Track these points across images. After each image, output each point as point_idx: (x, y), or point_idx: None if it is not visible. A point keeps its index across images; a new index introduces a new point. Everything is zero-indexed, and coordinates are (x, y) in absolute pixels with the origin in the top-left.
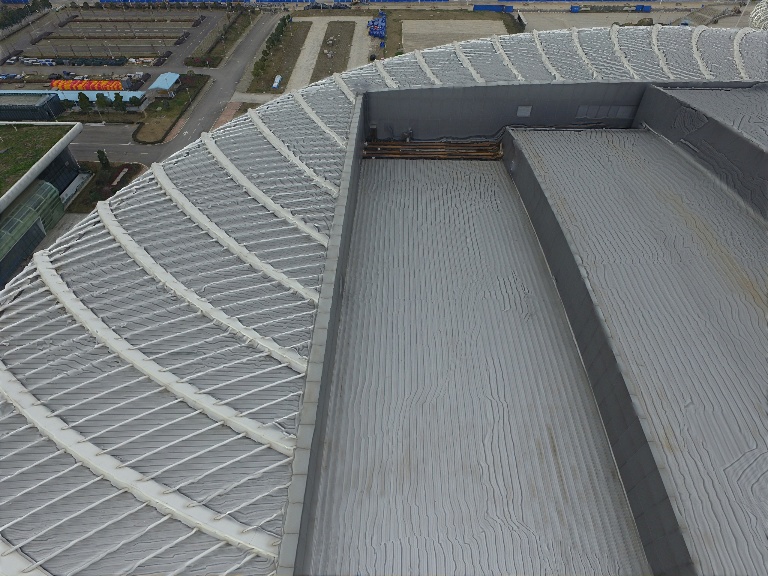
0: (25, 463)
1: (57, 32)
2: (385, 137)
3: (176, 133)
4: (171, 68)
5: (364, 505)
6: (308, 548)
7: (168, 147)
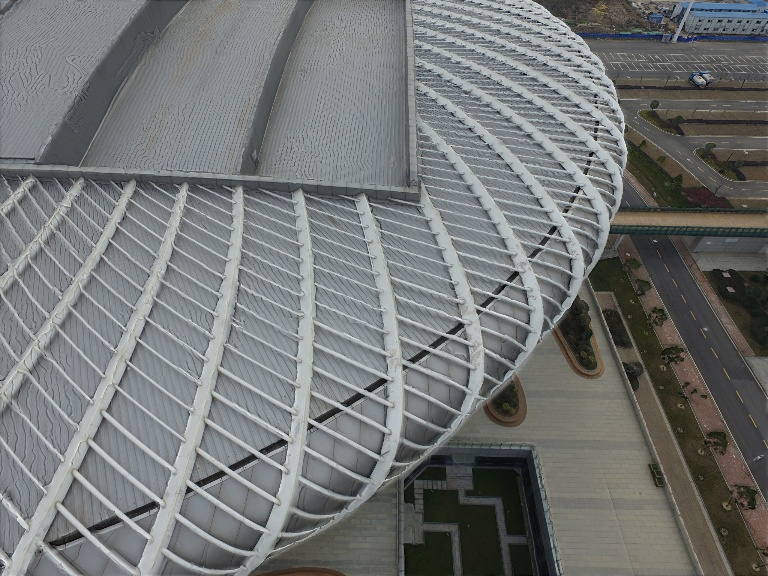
0: None
1: None
2: None
3: None
4: None
5: None
6: None
7: None
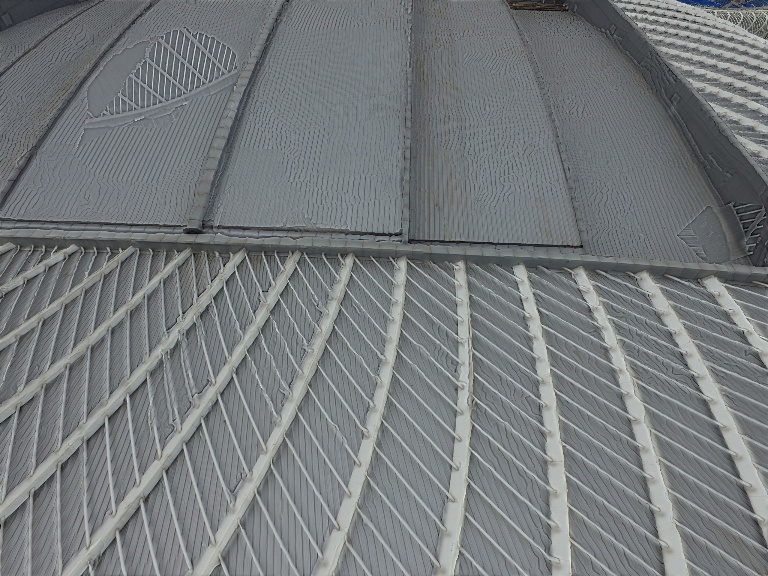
0: None
1: None
2: None
3: None
4: None
5: None
6: None
7: None
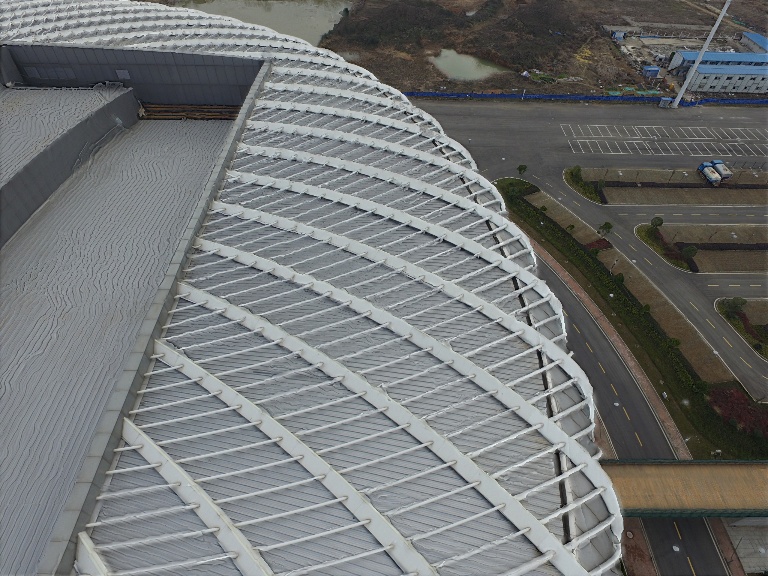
0: (392, 300)
1: None
2: None
3: None
4: None
5: None
6: None
7: None
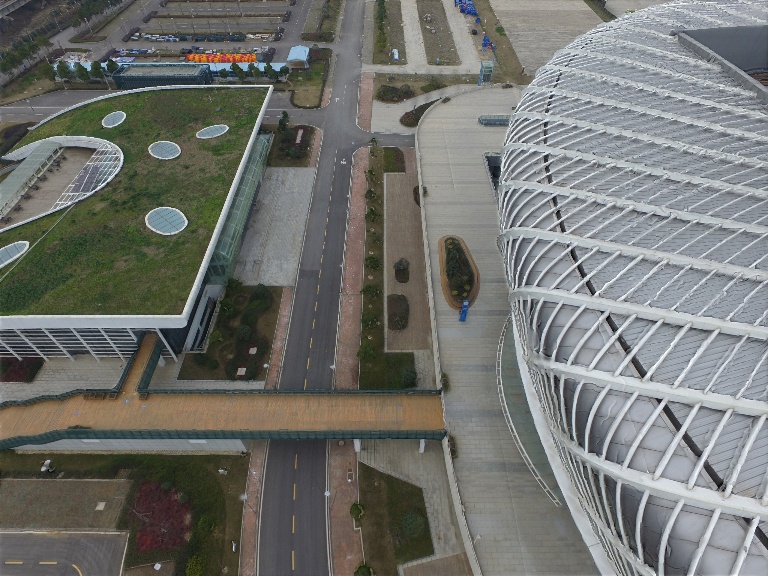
0: None
1: None
2: None
3: (328, 99)
4: (291, 43)
5: None
6: None
7: (328, 111)
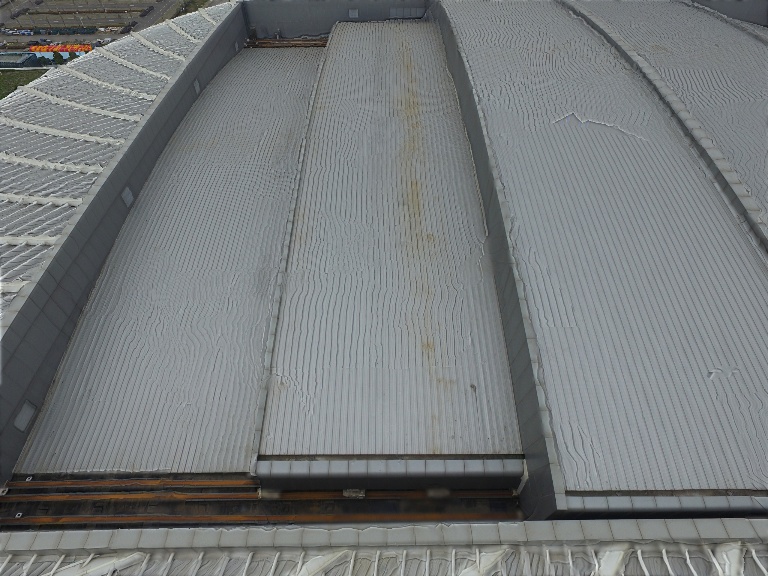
0: None
1: (34, 8)
2: (263, 36)
3: None
4: None
5: (186, 157)
6: (150, 157)
7: None
